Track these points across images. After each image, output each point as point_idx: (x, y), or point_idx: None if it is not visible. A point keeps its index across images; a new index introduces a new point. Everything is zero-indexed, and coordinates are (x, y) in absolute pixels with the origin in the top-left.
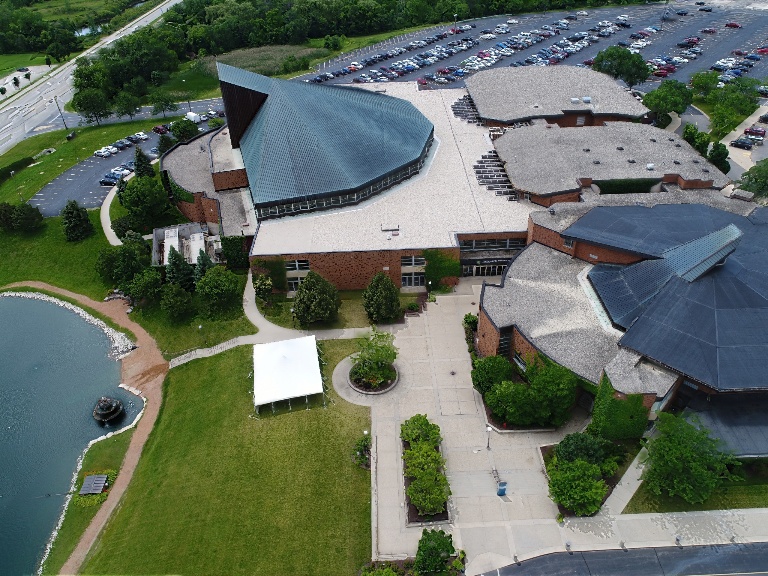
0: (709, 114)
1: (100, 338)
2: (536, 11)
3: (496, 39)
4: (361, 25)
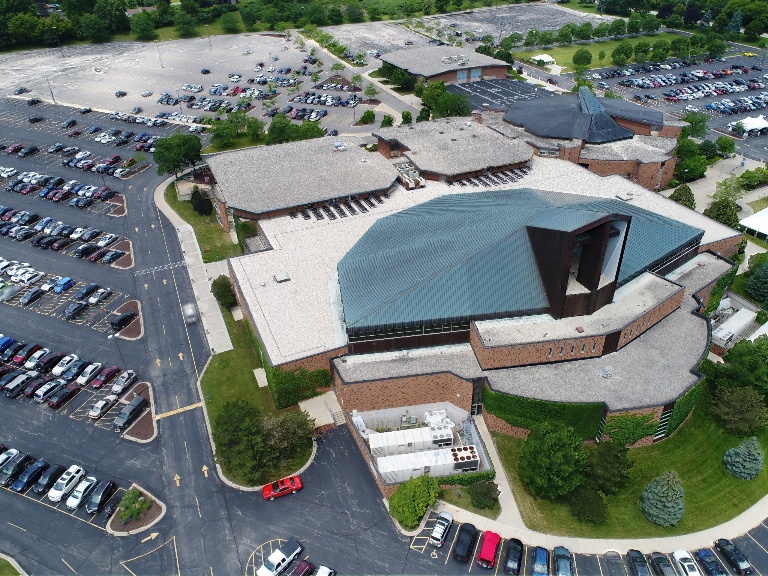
0: (261, 144)
1: None
2: None
3: None
4: None
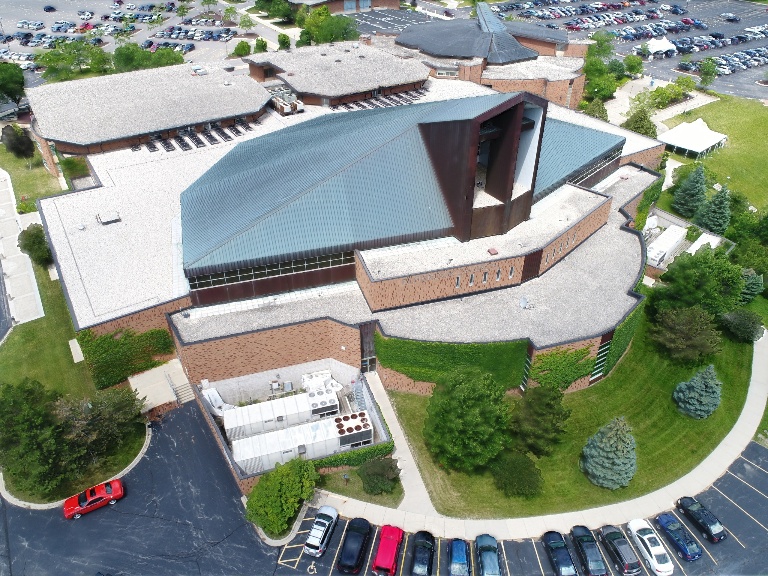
0: None
1: None
2: None
3: None
4: None
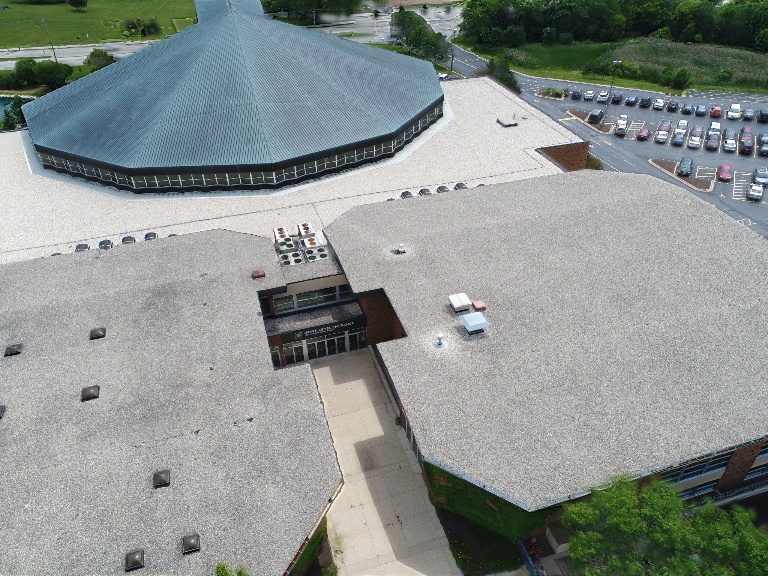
0: None
1: None
2: None
3: None
4: None
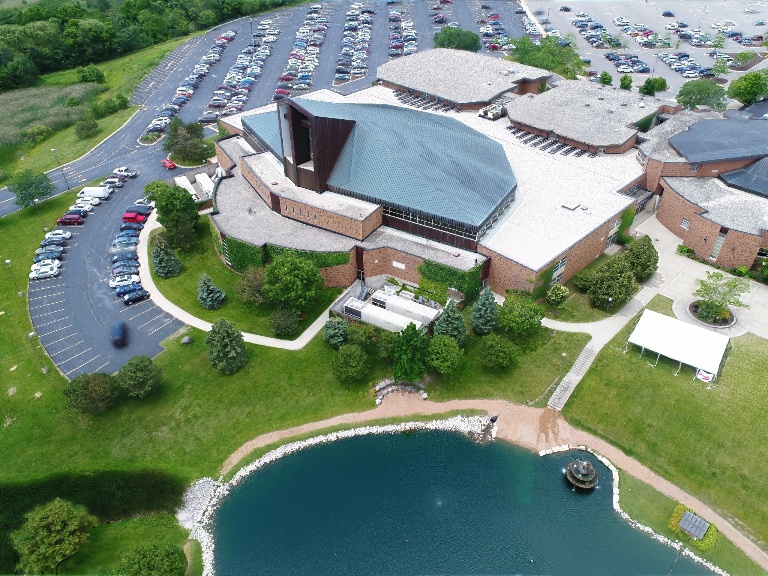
0: None
1: (438, 437)
2: (261, 10)
3: (280, 40)
4: (99, 49)
